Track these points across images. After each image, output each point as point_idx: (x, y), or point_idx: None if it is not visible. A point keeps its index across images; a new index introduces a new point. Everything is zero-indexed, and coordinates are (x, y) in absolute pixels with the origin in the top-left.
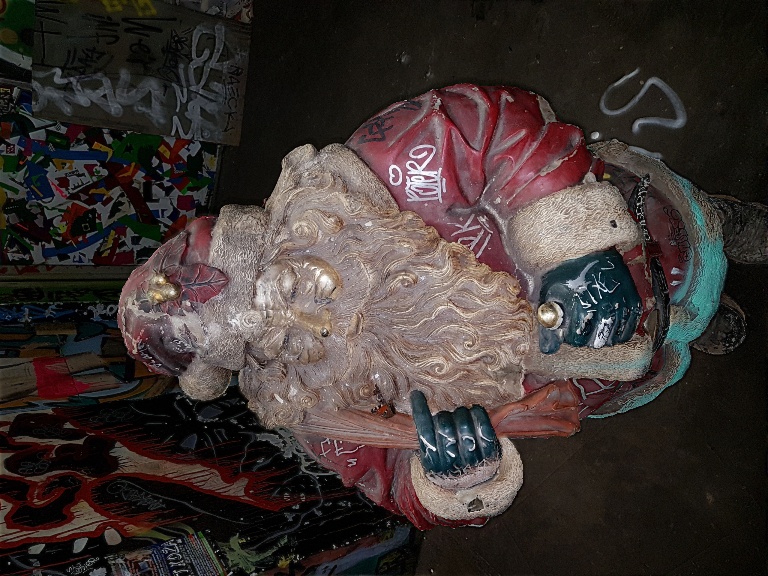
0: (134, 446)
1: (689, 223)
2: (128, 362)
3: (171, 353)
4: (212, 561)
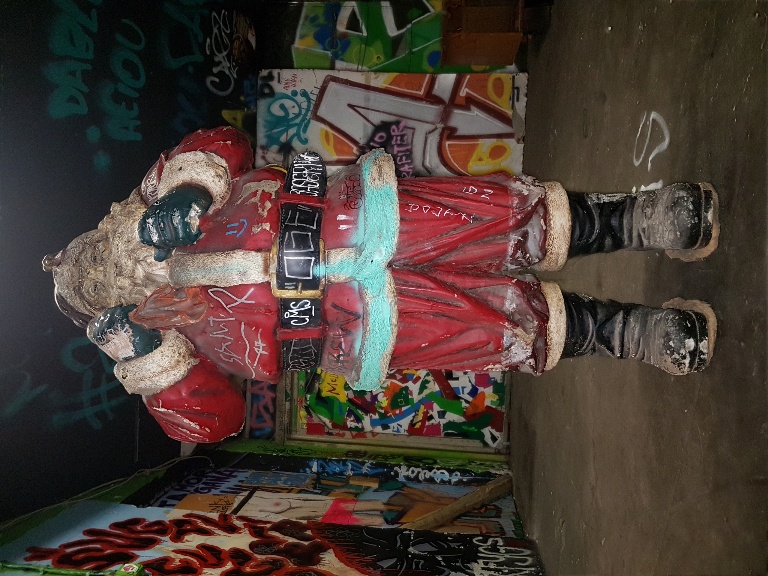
0: (340, 554)
1: (362, 180)
2: (402, 511)
3: (75, 310)
4: None
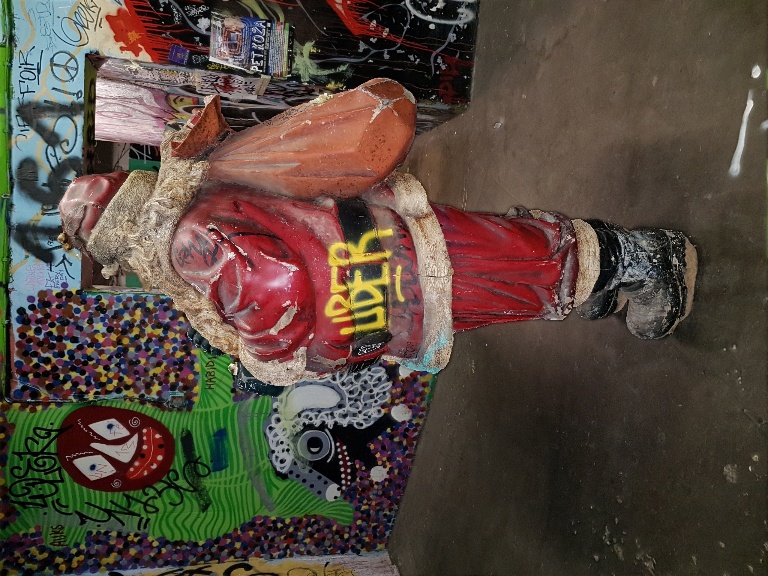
0: None
1: None
2: None
3: None
4: (283, 57)
